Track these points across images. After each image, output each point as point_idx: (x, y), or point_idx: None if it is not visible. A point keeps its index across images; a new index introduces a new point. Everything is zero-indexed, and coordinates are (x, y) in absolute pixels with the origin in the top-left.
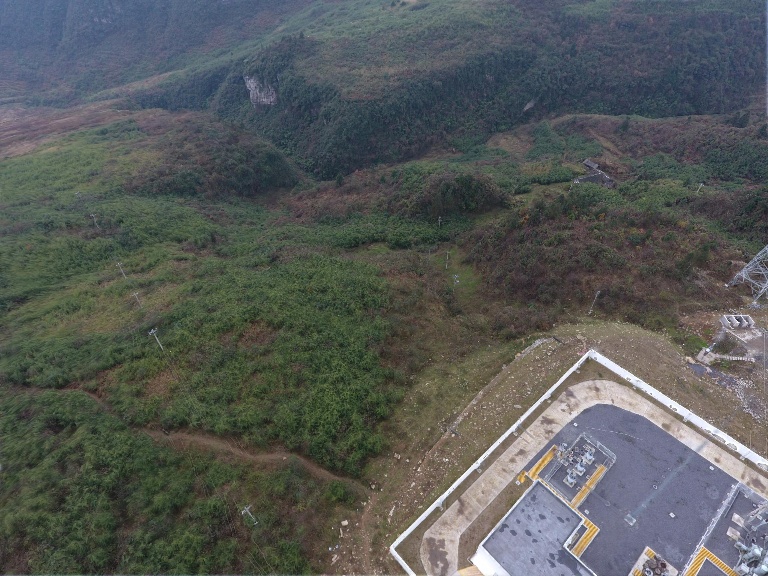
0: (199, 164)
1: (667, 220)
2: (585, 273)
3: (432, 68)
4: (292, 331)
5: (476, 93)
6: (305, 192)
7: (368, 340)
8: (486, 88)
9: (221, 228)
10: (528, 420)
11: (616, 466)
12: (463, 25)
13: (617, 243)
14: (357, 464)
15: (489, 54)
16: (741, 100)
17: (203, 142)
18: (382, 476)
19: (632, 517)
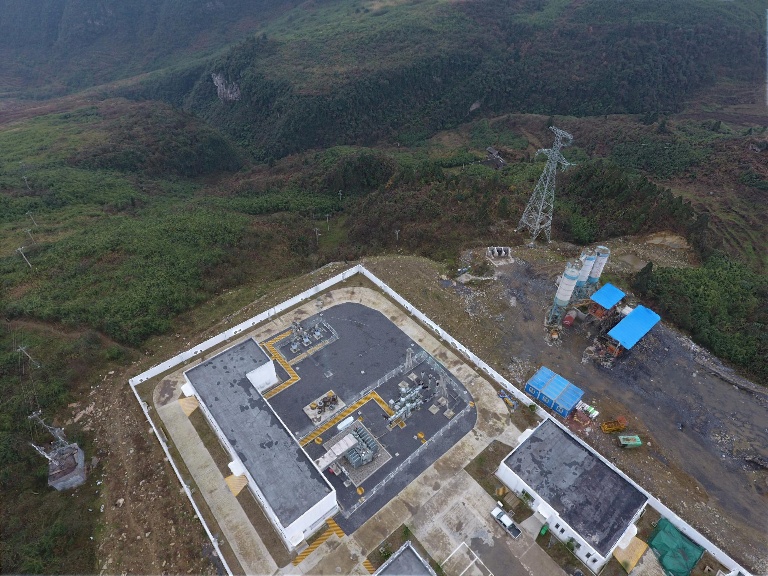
0: (144, 145)
1: (504, 186)
2: (409, 222)
3: (380, 68)
4: (140, 255)
5: (423, 93)
6: (242, 174)
7: (197, 262)
8: (433, 88)
9: (147, 197)
10: (285, 311)
11: (338, 341)
12: (414, 30)
13: (443, 199)
14: (137, 336)
15: (435, 57)
16: (675, 105)
17: (151, 126)
18: (157, 347)
19: (331, 372)
